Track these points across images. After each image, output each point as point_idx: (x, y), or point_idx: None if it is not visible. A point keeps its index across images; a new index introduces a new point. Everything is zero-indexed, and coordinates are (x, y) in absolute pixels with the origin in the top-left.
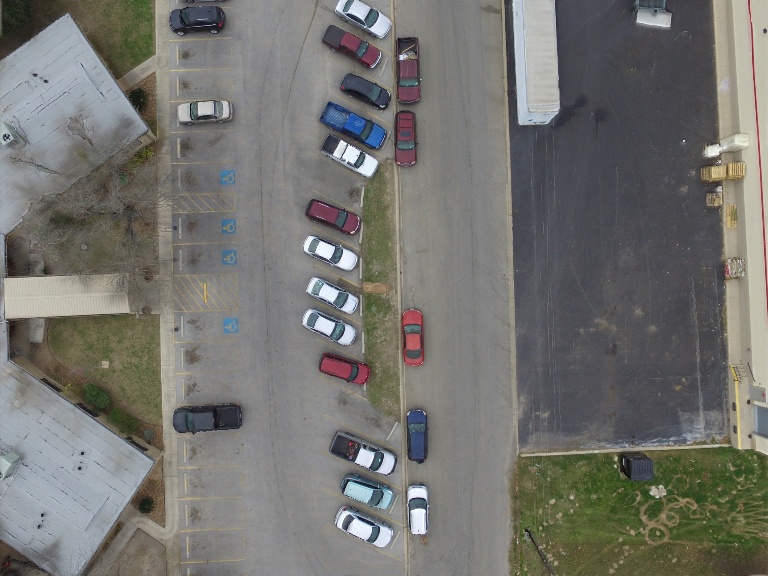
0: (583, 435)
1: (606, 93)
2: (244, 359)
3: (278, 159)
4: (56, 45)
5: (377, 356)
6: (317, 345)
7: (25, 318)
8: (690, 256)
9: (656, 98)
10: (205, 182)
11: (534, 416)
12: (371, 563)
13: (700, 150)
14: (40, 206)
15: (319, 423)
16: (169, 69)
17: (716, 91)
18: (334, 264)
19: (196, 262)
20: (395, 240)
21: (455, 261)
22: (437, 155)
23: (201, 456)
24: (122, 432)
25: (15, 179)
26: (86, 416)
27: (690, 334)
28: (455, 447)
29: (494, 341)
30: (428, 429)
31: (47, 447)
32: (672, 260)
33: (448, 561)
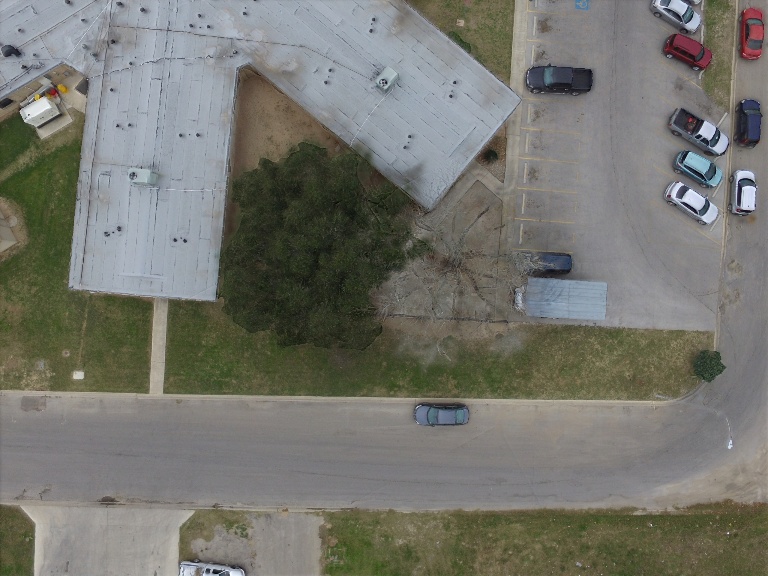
0: None
1: None
2: (592, 35)
3: None
4: None
5: (714, 49)
6: (660, 31)
7: None
8: None
9: None
10: None
11: None
12: (691, 242)
13: None
14: None
15: (656, 103)
16: None
17: None
18: None
19: None
20: None
21: None
22: None
23: (544, 119)
24: None
25: None
26: (460, 49)
27: None
28: None
29: None
30: (762, 116)
31: (419, 74)
32: None
33: (762, 249)
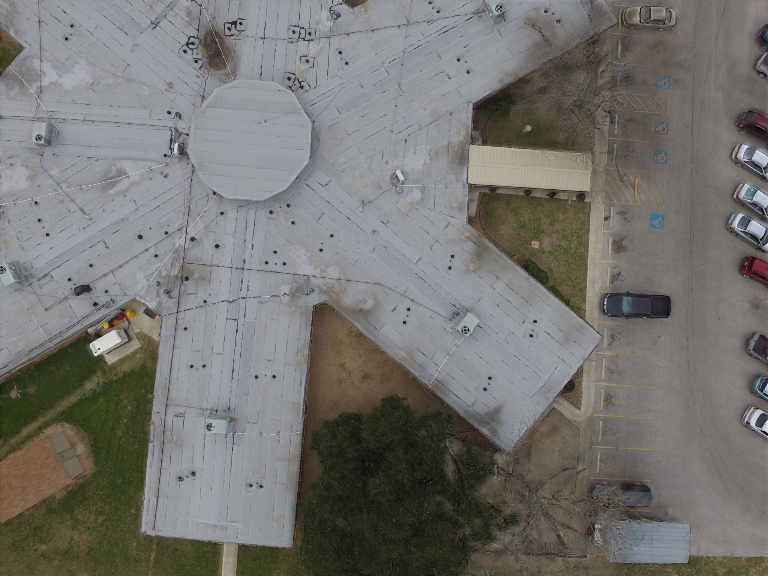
0: None
1: None
2: (667, 255)
3: (710, 71)
4: None
5: None
6: (736, 249)
7: (487, 185)
8: None
9: None
10: (642, 83)
11: None
12: None
13: None
14: (561, 70)
15: (732, 324)
16: None
17: None
18: (763, 174)
19: (628, 157)
20: None
21: None
22: None
23: (620, 343)
24: None
25: (487, 52)
26: (540, 286)
27: None
28: None
29: None
30: None
31: (499, 312)
32: None
33: None
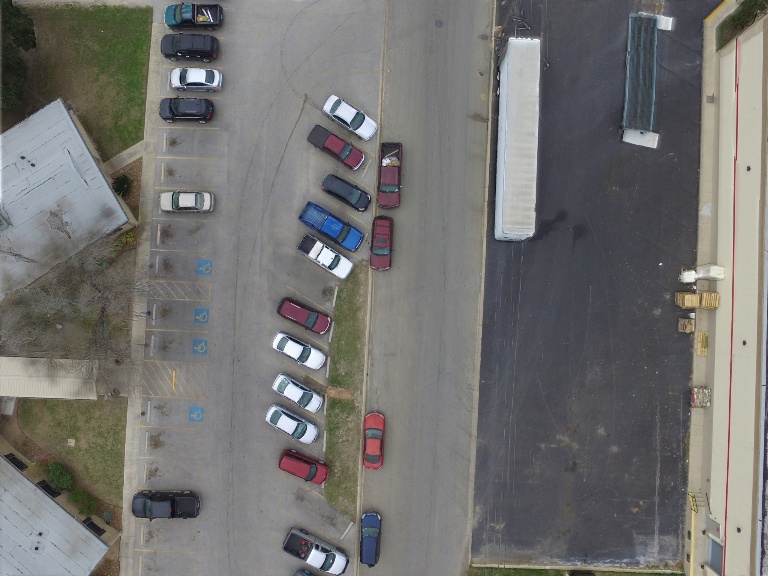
0: (536, 550)
1: (586, 210)
2: (207, 448)
3: (255, 253)
4: (45, 129)
5: (337, 455)
6: (279, 440)
7: None
8: (657, 380)
9: (636, 219)
10: (182, 270)
11: (489, 527)
12: None
13: (676, 274)
14: (13, 299)
15: (275, 517)
16: (155, 155)
17: (697, 216)
18: (301, 363)
19: (167, 349)
20: (364, 342)
21: (422, 367)
22: (412, 260)
23: (158, 540)
24: (81, 513)
25: None
26: (47, 497)
27: (651, 458)
28: (408, 552)
29: (454, 450)
30: (381, 534)
31: (7, 524)
32: (639, 383)
33: None
